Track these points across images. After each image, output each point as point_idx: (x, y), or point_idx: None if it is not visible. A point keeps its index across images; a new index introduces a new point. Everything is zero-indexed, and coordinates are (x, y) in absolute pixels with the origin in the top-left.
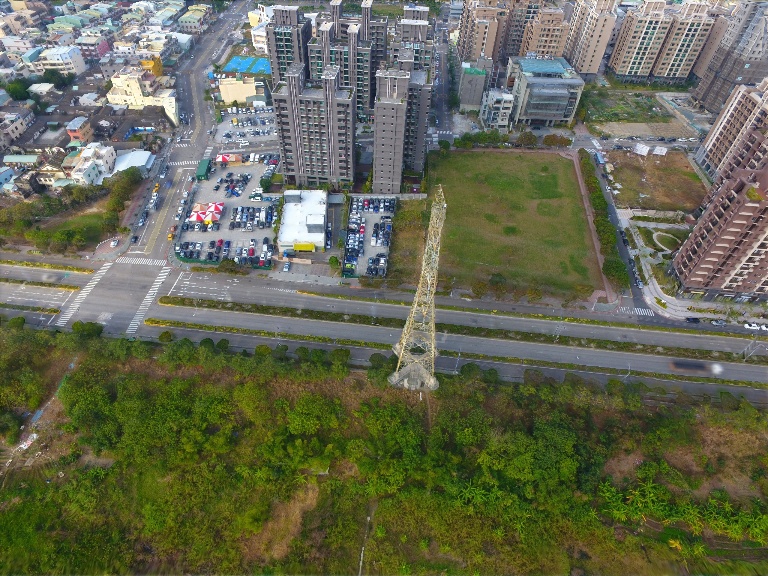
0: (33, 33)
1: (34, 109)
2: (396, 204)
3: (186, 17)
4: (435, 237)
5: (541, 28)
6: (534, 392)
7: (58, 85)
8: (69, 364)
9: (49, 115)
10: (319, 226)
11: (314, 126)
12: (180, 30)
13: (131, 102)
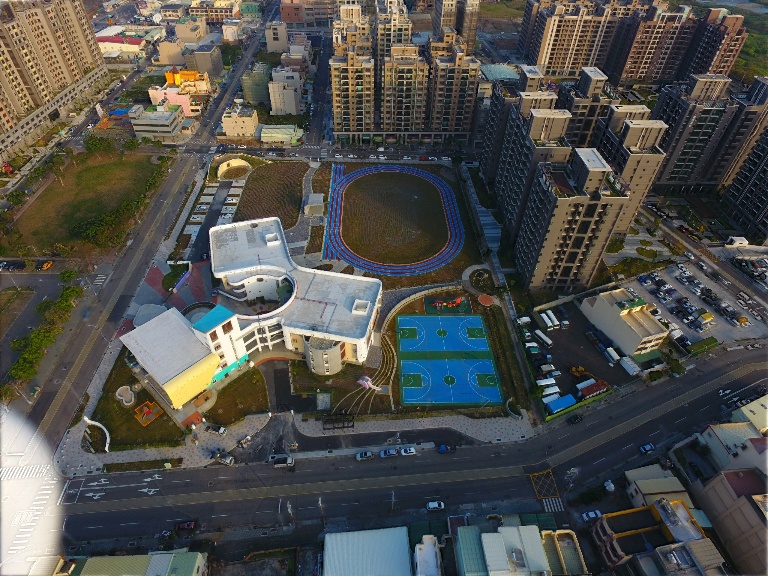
0: None
1: None
2: None
3: None
4: None
5: (465, 47)
6: None
7: None
8: None
9: None
10: None
11: None
12: None
13: None
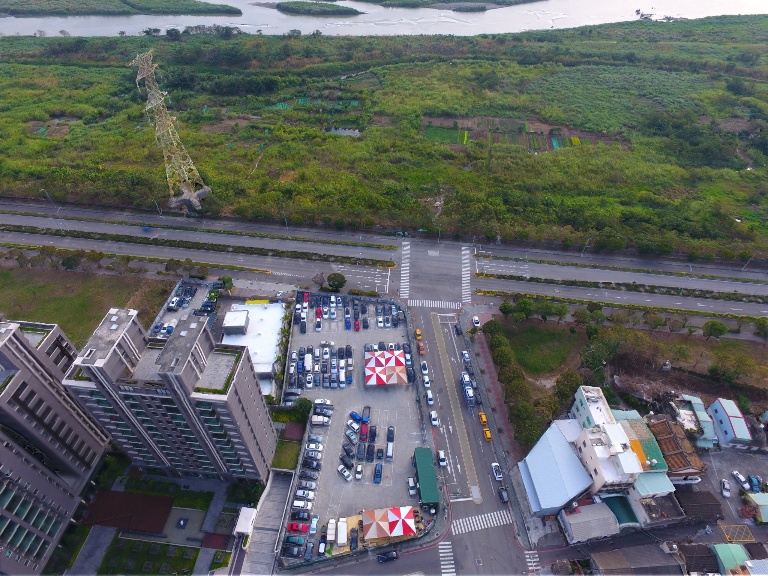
0: None
1: None
2: None
3: None
4: None
5: None
6: None
7: None
8: None
9: None
10: None
11: None
12: None
13: None
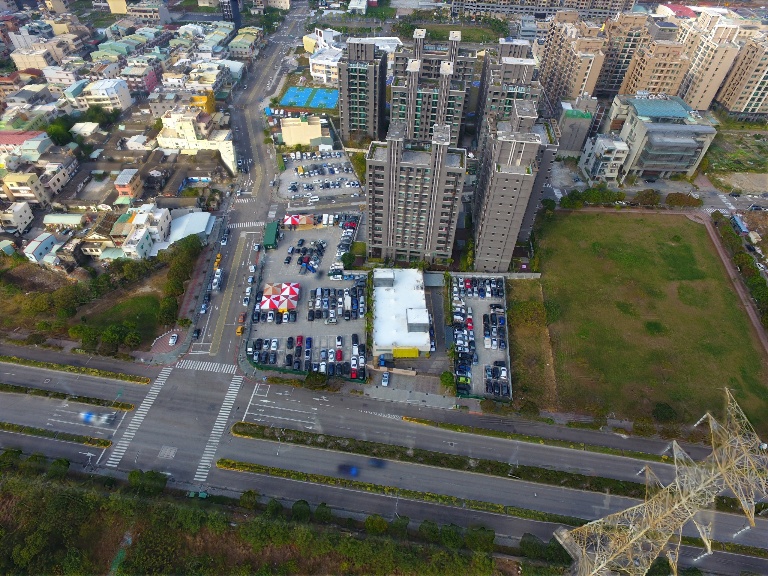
0: (76, 63)
1: (77, 154)
2: (505, 286)
3: (237, 42)
4: (747, 498)
5: (656, 63)
6: None
7: (103, 123)
8: (124, 532)
9: (94, 162)
10: (423, 325)
11: (414, 196)
12: (230, 56)
13: (183, 145)
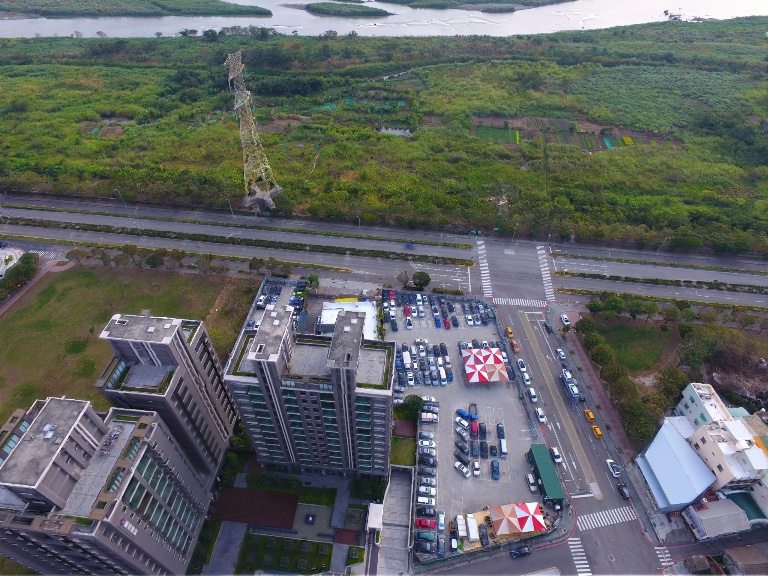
0: None
1: None
2: None
3: None
4: None
5: None
6: (191, 186)
7: None
8: None
9: None
10: None
11: None
12: None
13: None
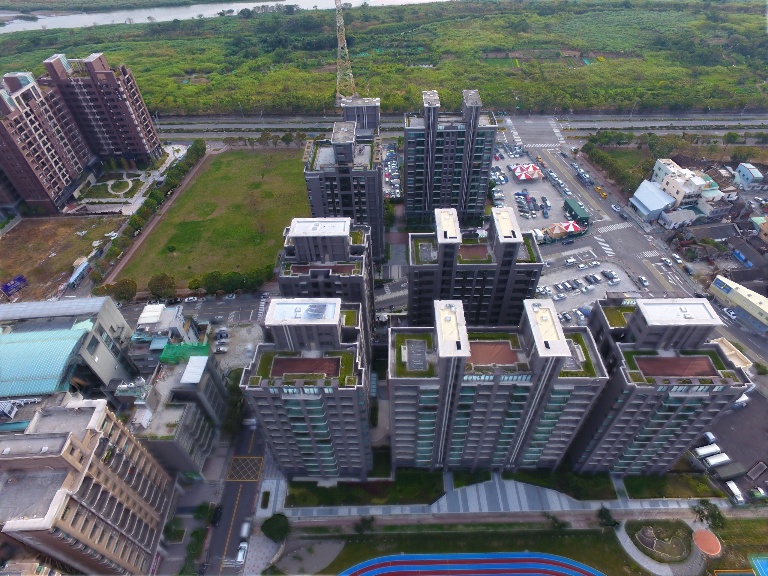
0: None
1: None
2: None
3: None
4: None
5: None
6: (291, 99)
7: None
8: None
9: None
10: None
11: None
12: None
13: None
